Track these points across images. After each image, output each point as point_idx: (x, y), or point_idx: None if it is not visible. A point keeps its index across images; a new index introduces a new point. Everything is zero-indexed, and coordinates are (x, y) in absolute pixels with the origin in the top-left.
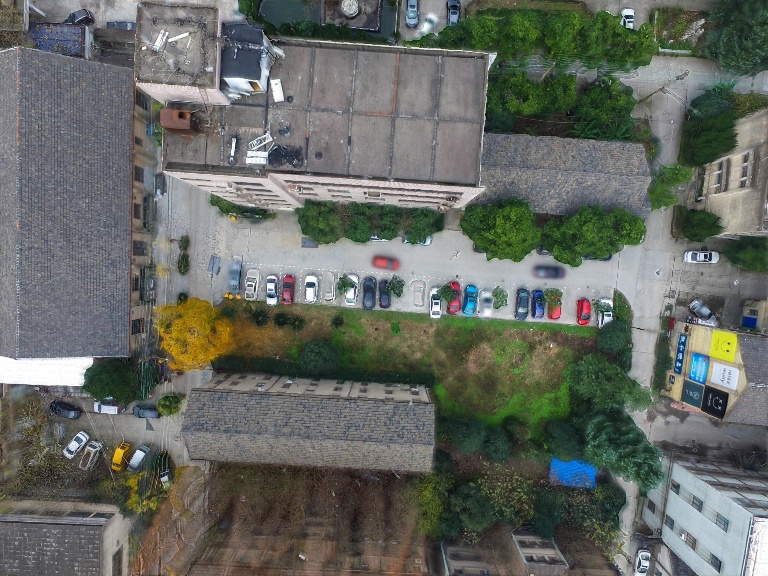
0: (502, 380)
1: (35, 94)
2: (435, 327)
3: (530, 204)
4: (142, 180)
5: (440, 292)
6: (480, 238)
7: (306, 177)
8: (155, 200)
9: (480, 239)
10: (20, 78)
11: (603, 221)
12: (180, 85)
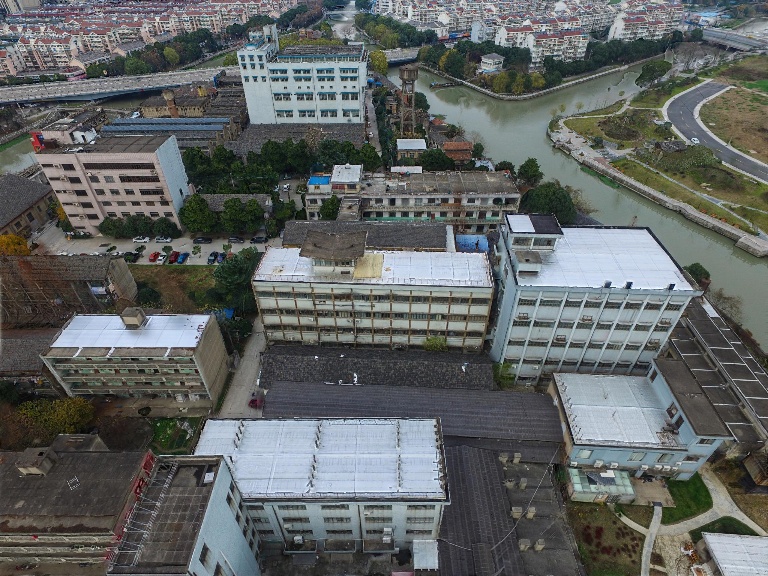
0: (190, 288)
1: (4, 183)
2: (158, 269)
3: (213, 208)
4: (30, 221)
5: (164, 249)
6: (185, 218)
7: (89, 155)
8: (32, 233)
9: (185, 218)
10: (2, 178)
11: (236, 199)
12: (56, 131)
